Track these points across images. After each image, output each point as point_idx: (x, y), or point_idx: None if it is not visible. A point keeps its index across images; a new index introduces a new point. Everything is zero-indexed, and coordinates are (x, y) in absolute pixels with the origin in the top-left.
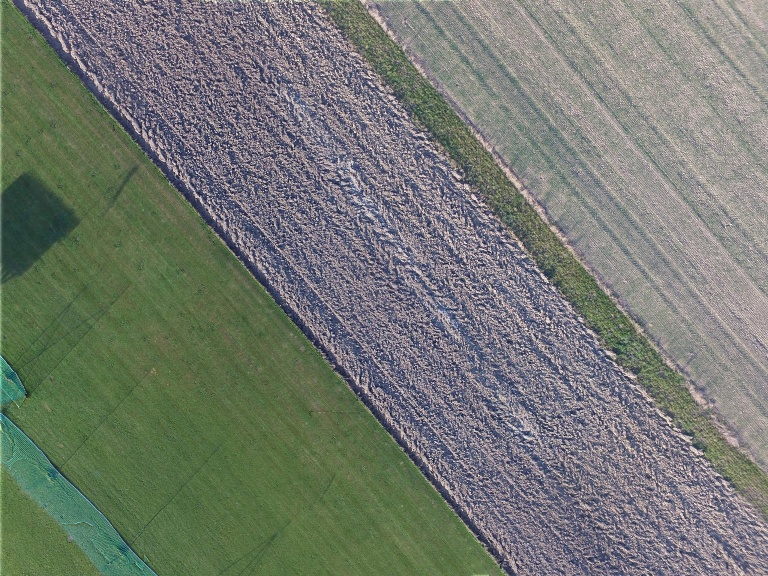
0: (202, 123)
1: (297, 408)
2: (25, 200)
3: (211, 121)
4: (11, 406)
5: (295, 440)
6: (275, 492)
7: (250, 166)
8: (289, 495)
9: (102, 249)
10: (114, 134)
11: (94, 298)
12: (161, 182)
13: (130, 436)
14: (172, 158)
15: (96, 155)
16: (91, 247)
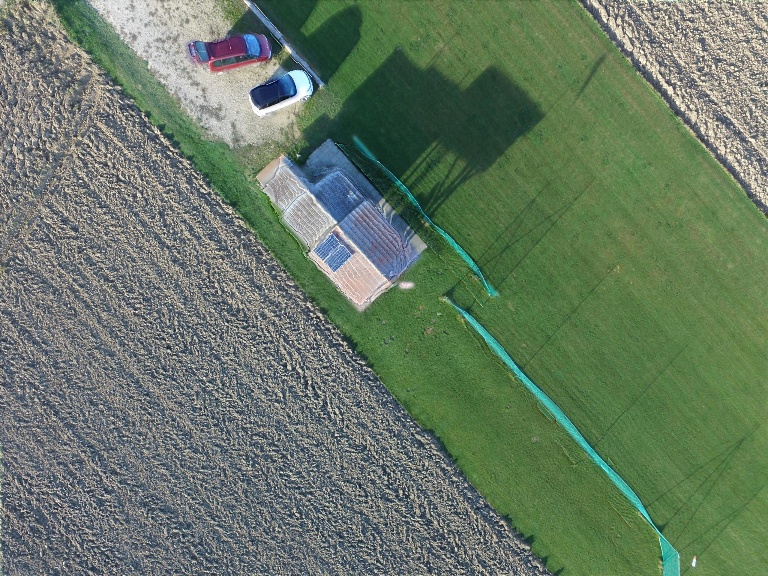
0: (672, 9)
1: (767, 308)
2: (491, 93)
3: (681, 6)
4: (475, 304)
5: (765, 341)
6: (743, 395)
7: (721, 53)
8: (759, 398)
9: (566, 143)
10: (582, 22)
11: (557, 194)
12: (628, 72)
13: (592, 336)
14: (641, 46)
15: (564, 45)
16: (555, 141)
